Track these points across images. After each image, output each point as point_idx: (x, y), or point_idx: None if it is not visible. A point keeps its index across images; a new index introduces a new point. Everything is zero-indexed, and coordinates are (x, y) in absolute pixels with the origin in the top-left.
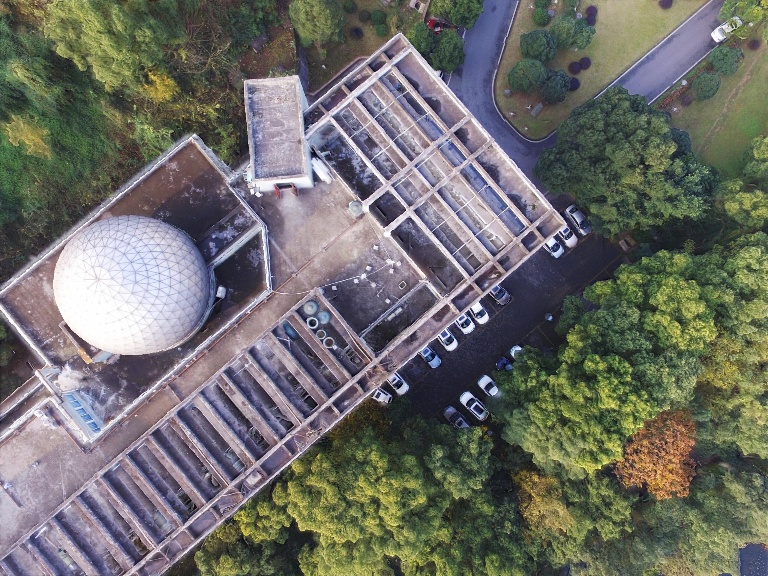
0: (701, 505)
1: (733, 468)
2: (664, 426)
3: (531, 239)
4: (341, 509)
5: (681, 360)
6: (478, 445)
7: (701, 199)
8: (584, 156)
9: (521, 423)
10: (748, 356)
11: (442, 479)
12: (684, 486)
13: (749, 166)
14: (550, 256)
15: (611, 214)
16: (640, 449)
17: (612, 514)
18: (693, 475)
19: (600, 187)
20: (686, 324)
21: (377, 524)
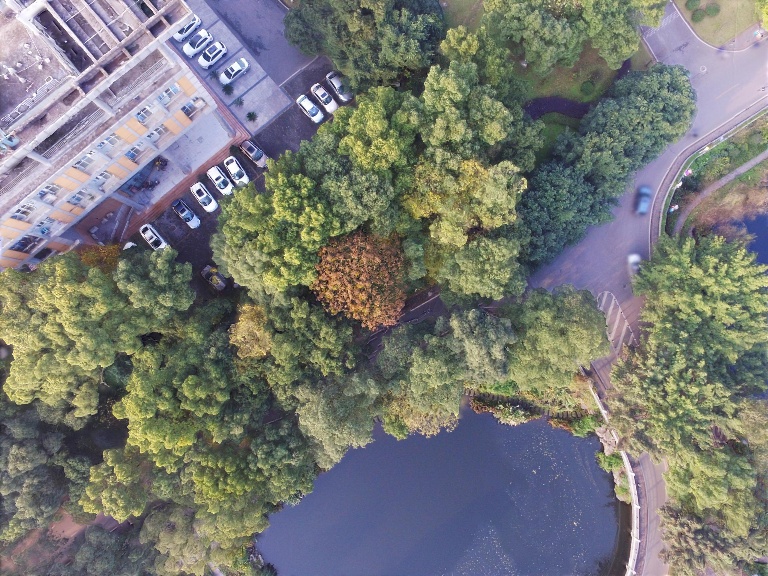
0: (426, 345)
1: (460, 310)
2: (351, 245)
3: (161, 28)
4: (22, 317)
5: (361, 176)
6: (169, 263)
7: (417, 42)
8: (316, 8)
9: (219, 246)
10: (445, 183)
11: (129, 293)
12: (388, 314)
13: (481, 19)
14: (311, 121)
15: (351, 69)
16: (326, 266)
17: (320, 343)
18: (401, 306)
19: (330, 37)
20: (371, 144)
21: (58, 332)
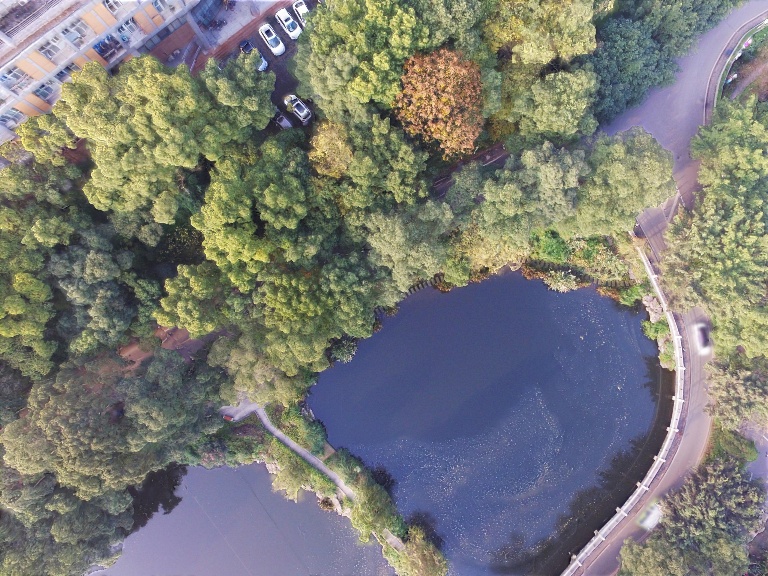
0: (497, 179)
1: None
2: (438, 57)
3: None
4: (110, 107)
5: None
6: None
7: None
8: None
9: (304, 57)
10: (530, 5)
11: (216, 92)
12: (467, 136)
13: None
14: None
15: None
16: (413, 76)
17: (398, 164)
18: (479, 131)
19: None
20: None
21: (146, 125)
